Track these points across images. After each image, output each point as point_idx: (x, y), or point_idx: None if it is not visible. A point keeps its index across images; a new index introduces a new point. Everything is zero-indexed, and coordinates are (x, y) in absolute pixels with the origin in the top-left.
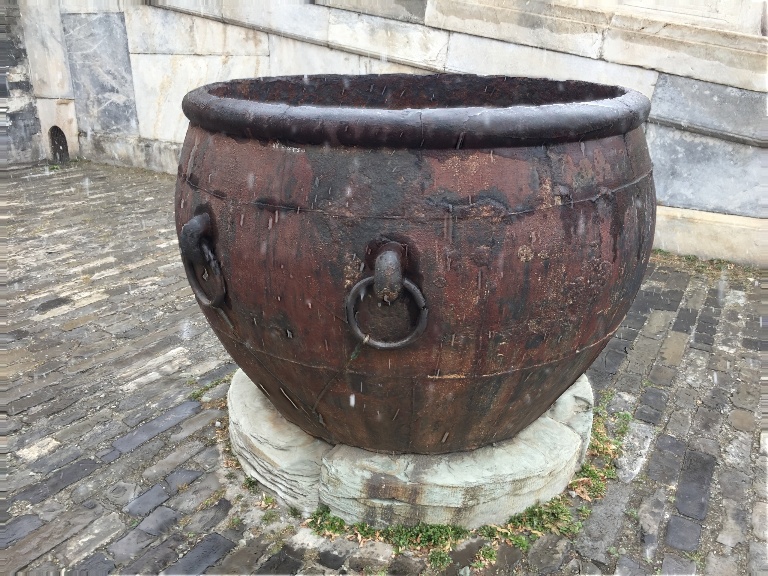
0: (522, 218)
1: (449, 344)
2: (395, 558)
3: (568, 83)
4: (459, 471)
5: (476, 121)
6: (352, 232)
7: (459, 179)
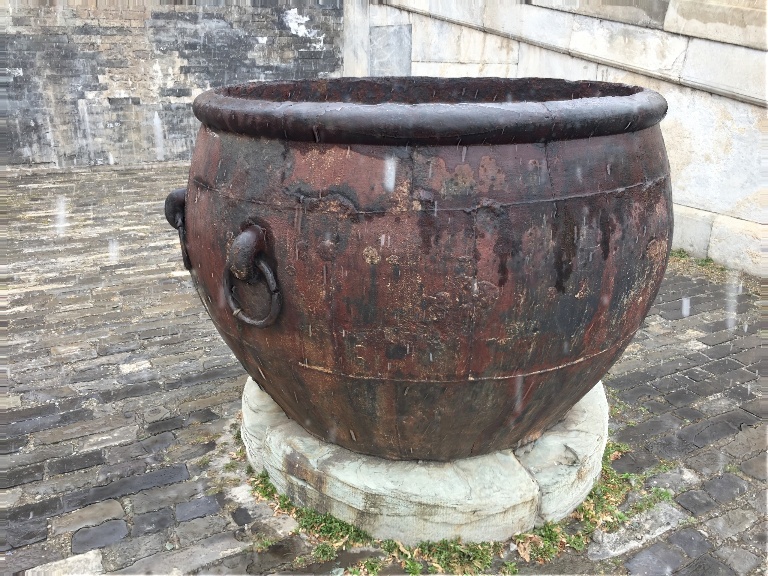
0: (371, 218)
1: (307, 334)
2: (291, 536)
3: (633, 90)
4: (364, 474)
5: (346, 116)
6: (232, 212)
7: (314, 172)
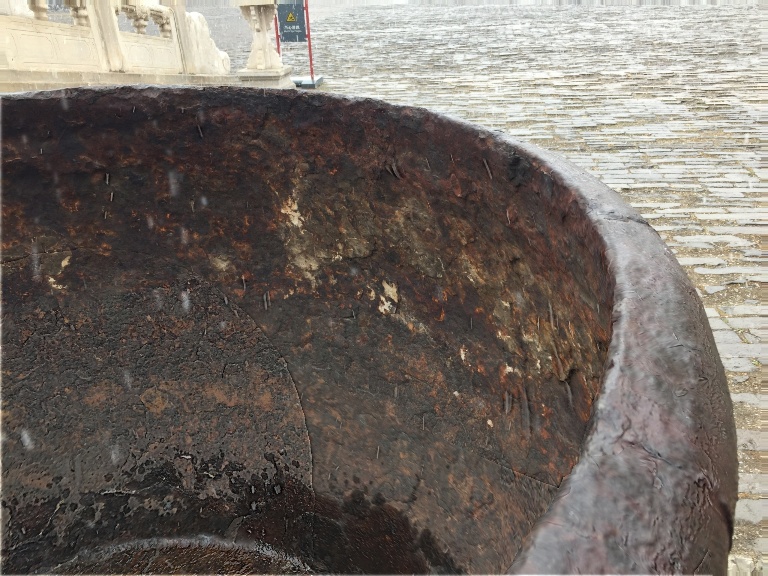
0: None
1: None
2: None
3: None
4: None
5: (420, 131)
6: None
7: None
